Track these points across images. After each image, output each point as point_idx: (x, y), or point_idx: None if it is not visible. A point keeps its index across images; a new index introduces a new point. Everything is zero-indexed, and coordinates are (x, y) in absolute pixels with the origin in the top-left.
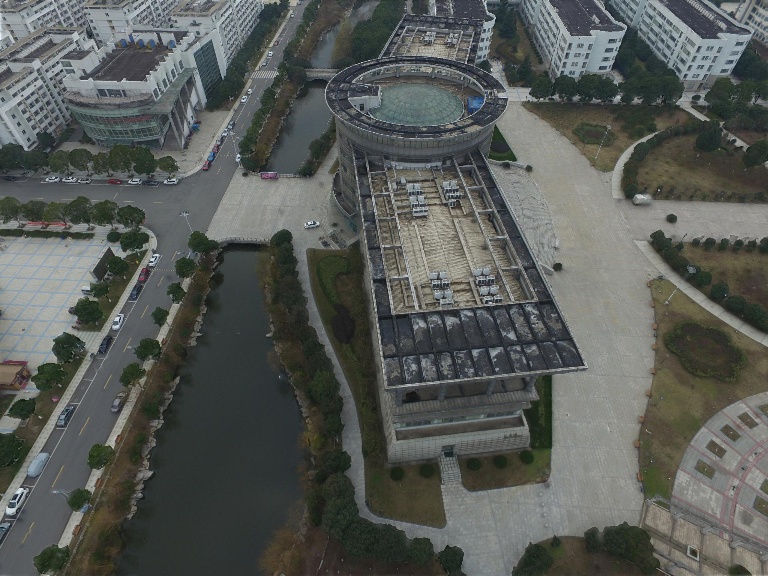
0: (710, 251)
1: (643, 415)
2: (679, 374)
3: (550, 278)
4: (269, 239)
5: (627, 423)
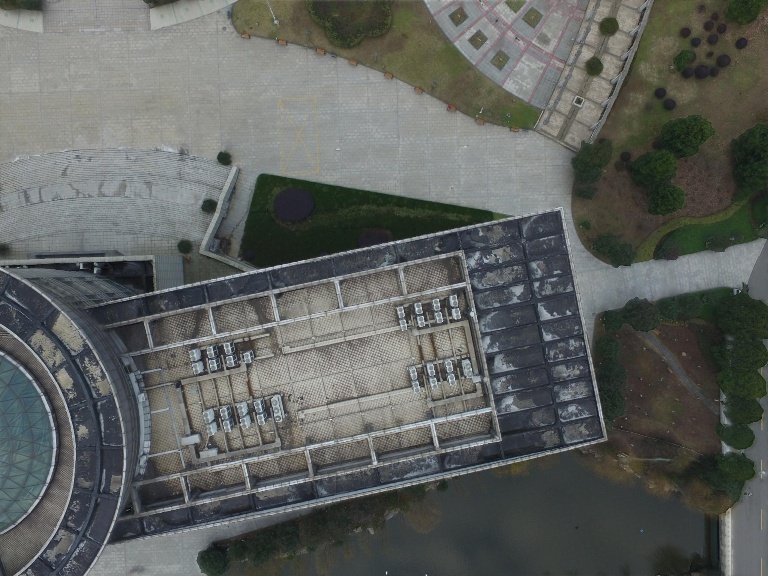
0: None
1: (446, 105)
2: (389, 46)
3: (246, 173)
4: None
5: (457, 125)
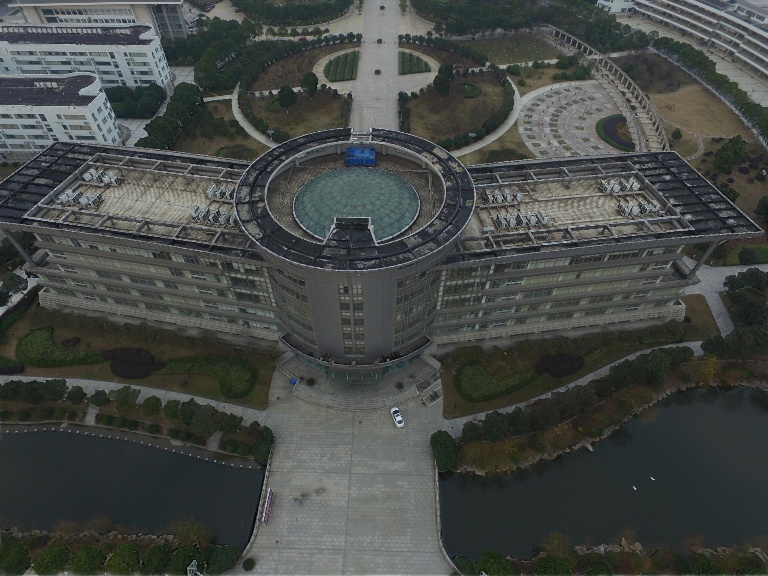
0: None
1: None
2: None
3: None
4: (436, 473)
5: None
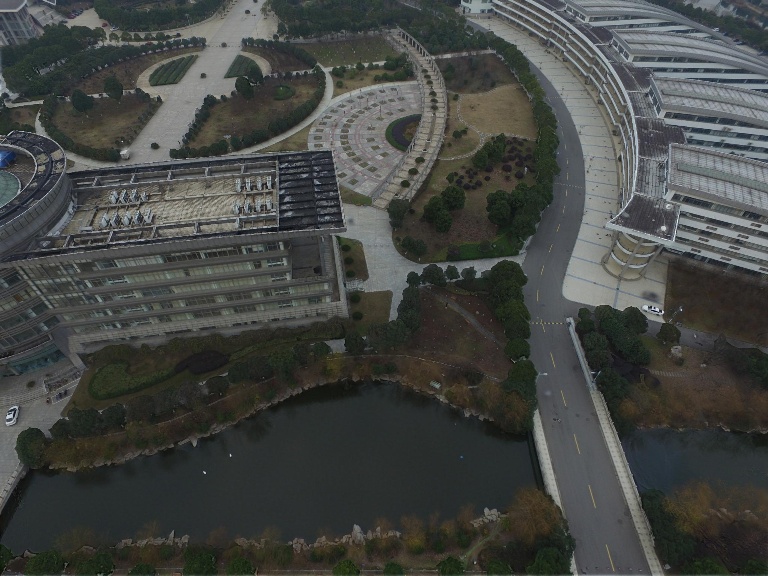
0: (195, 140)
1: None
2: None
3: None
4: (15, 470)
5: None
